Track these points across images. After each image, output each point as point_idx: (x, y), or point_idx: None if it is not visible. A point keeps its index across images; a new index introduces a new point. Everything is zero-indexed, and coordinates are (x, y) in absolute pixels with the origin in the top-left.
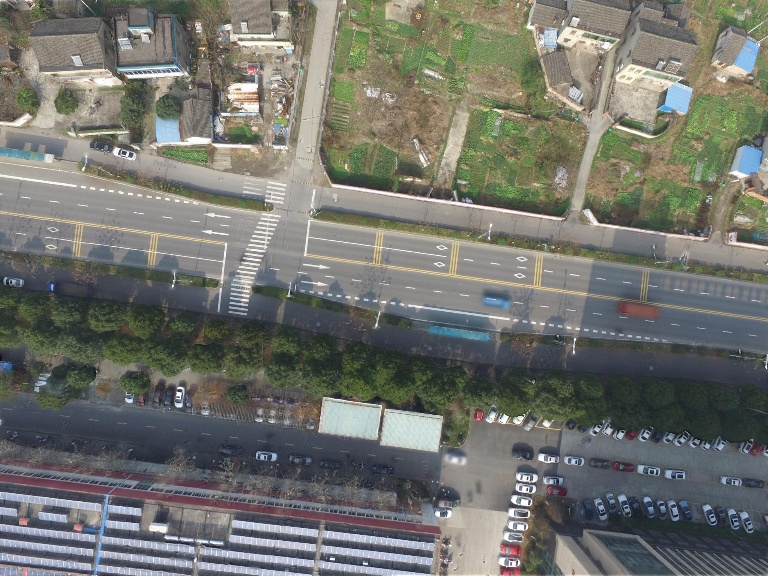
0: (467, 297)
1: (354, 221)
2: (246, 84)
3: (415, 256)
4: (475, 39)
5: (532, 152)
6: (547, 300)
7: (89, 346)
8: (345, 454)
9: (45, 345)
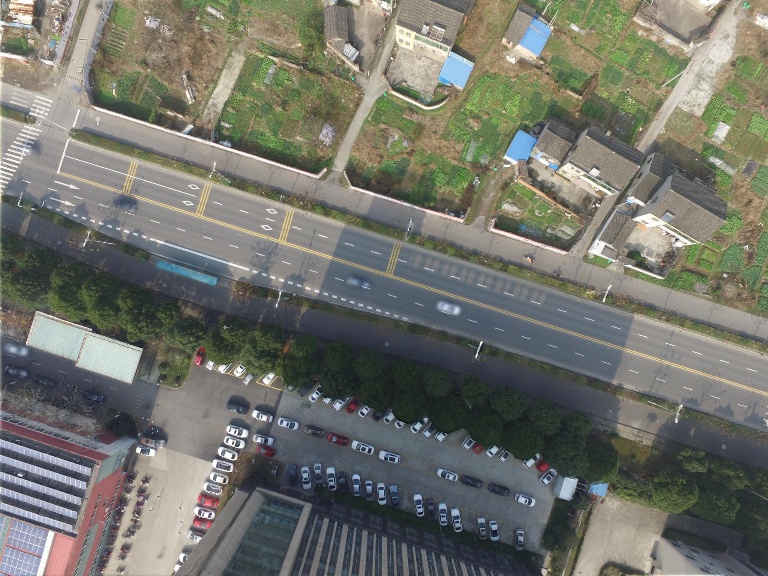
0: (210, 240)
1: (109, 146)
2: None
3: (165, 191)
4: None
5: (302, 105)
6: (290, 257)
7: None
8: (62, 375)
9: None
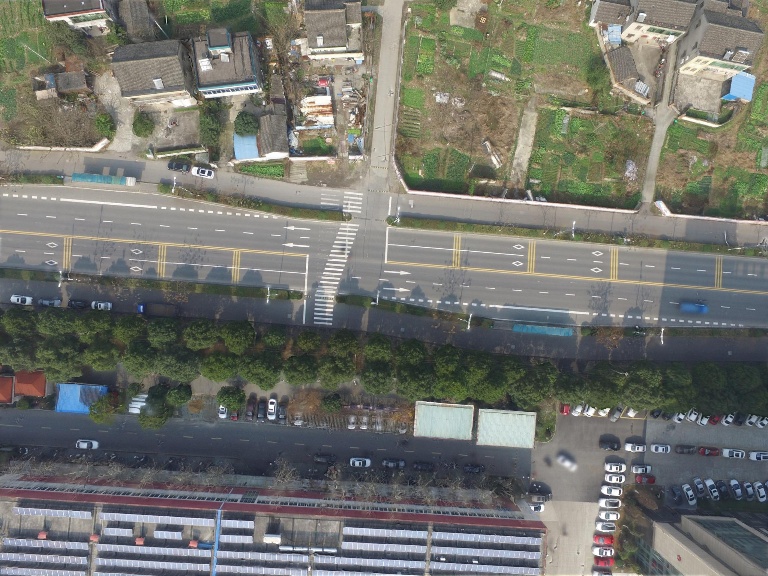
0: (546, 294)
1: (432, 226)
2: (320, 97)
3: (493, 257)
4: (539, 39)
5: (601, 148)
6: (624, 292)
7: (188, 365)
8: (437, 456)
9: (144, 366)
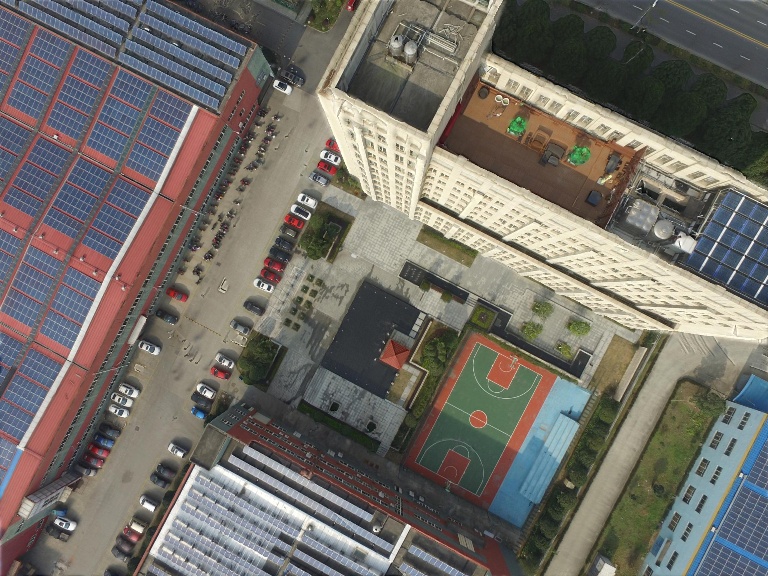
0: None
1: None
2: None
3: None
4: None
5: None
6: None
7: None
8: (212, 2)
9: None
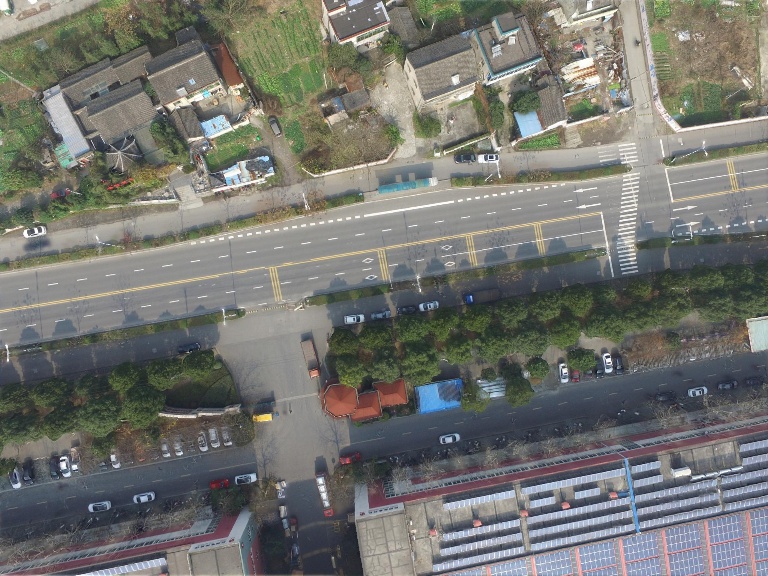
0: None
1: (707, 157)
2: (582, 60)
3: (766, 173)
4: None
5: None
6: None
7: (548, 335)
8: (762, 368)
9: (508, 347)
